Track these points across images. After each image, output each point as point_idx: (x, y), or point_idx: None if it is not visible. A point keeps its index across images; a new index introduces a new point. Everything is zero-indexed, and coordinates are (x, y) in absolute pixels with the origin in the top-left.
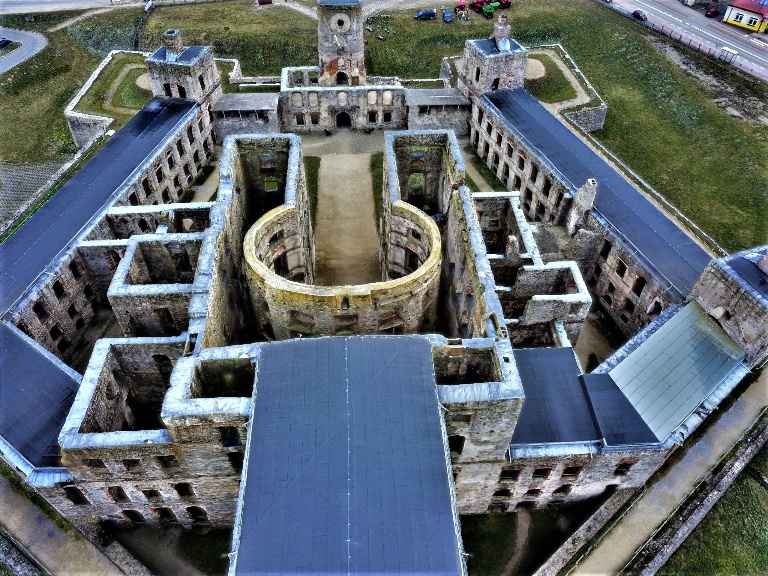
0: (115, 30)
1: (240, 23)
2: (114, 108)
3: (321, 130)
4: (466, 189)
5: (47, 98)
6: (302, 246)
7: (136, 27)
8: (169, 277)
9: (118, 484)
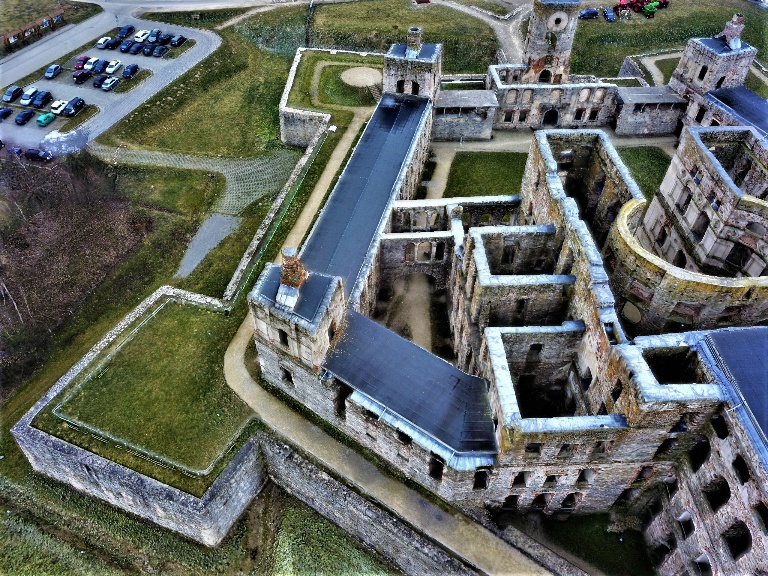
0: (284, 28)
1: (406, 21)
2: (324, 104)
3: (526, 127)
4: None
5: (236, 94)
6: None
7: (305, 25)
8: (490, 269)
9: (534, 469)
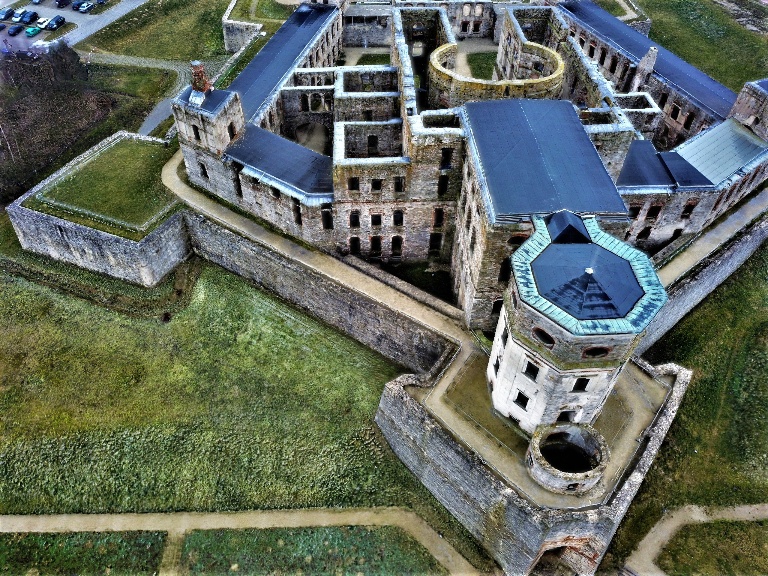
0: None
1: None
2: (259, 18)
3: None
4: (572, 38)
5: (191, 18)
6: None
7: None
8: None
9: (359, 206)
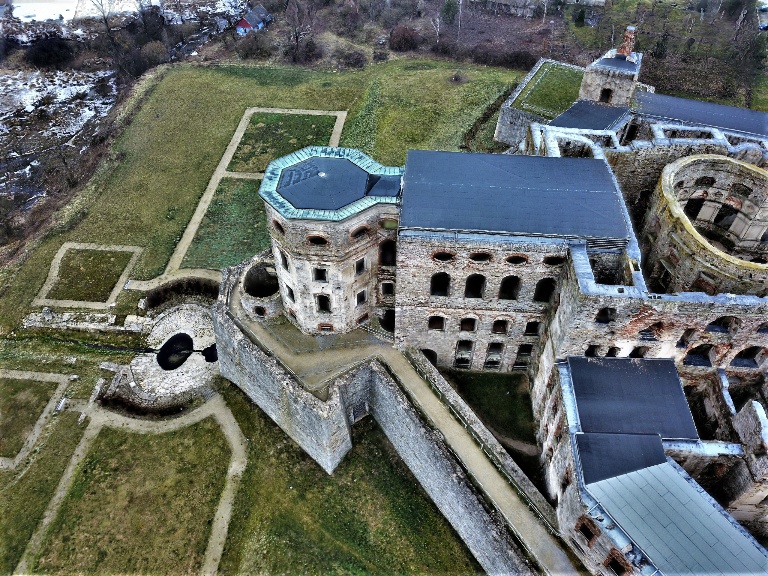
0: None
1: None
2: None
3: None
4: None
5: None
6: (761, 232)
7: None
8: None
9: None
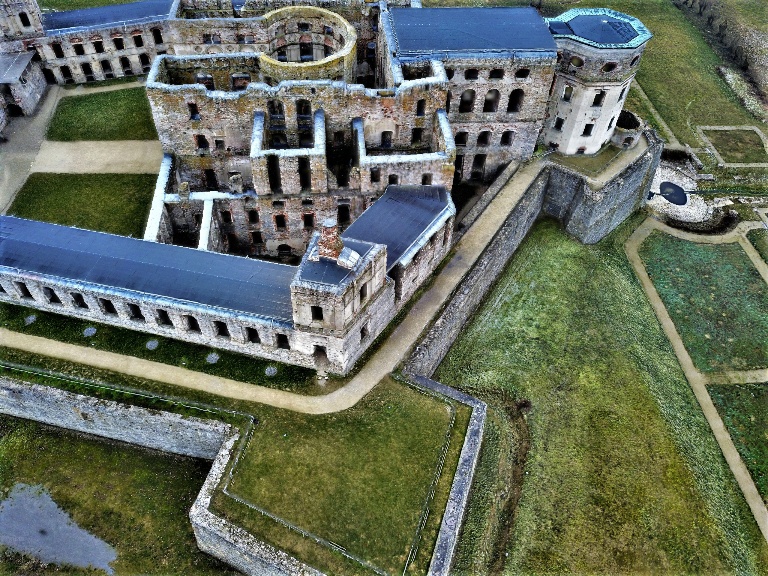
0: None
1: None
2: None
3: None
4: None
5: None
6: None
7: None
8: None
9: None
